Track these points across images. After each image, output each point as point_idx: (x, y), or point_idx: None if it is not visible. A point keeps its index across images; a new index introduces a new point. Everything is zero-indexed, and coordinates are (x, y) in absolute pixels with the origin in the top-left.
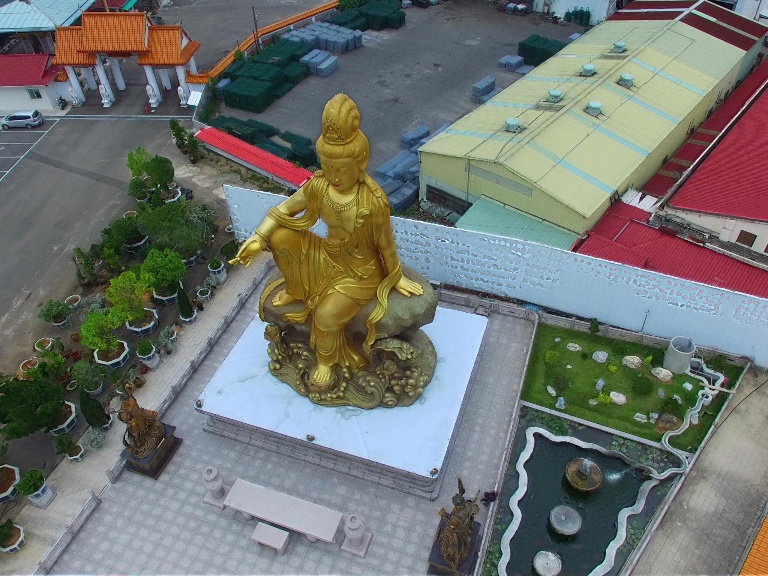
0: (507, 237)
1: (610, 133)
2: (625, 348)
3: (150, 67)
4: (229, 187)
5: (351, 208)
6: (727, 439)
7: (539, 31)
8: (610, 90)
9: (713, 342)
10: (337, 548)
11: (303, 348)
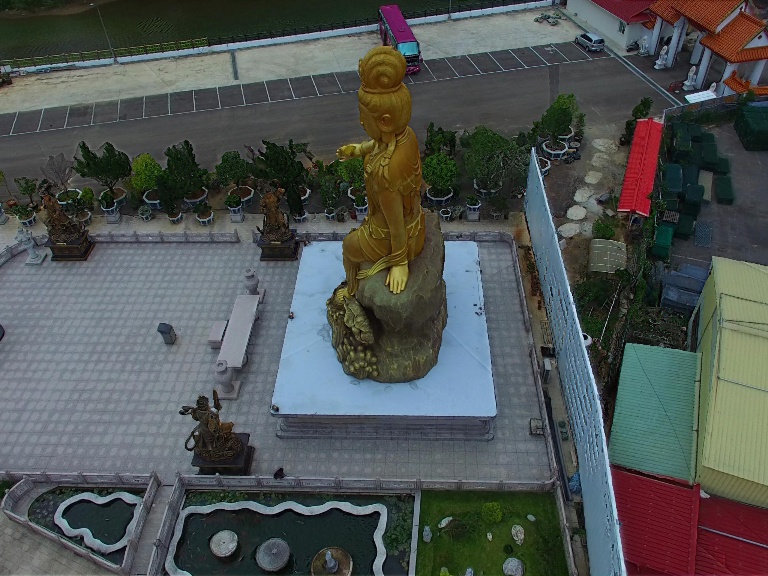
0: None
1: None
2: None
3: (710, 50)
4: (533, 152)
5: None
6: None
7: None
8: None
9: None
10: None
11: None
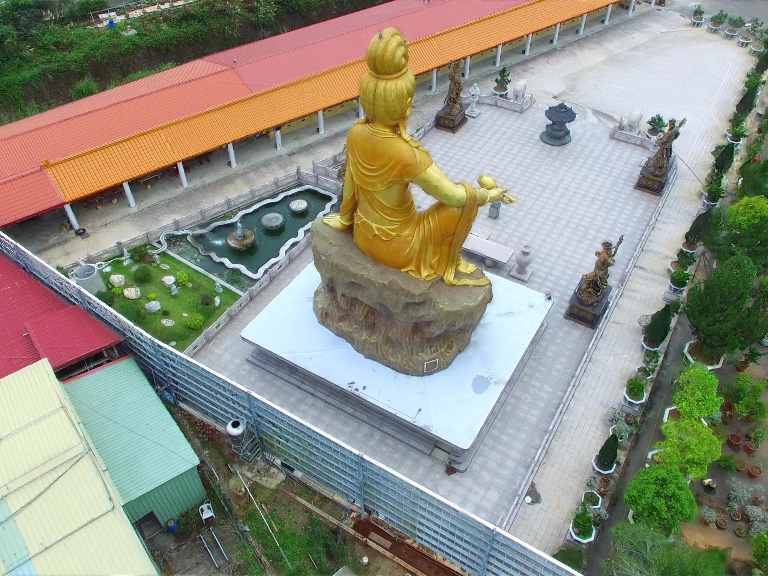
0: (171, 349)
1: None
2: None
3: None
4: None
5: None
6: None
7: None
8: None
9: None
10: None
11: None
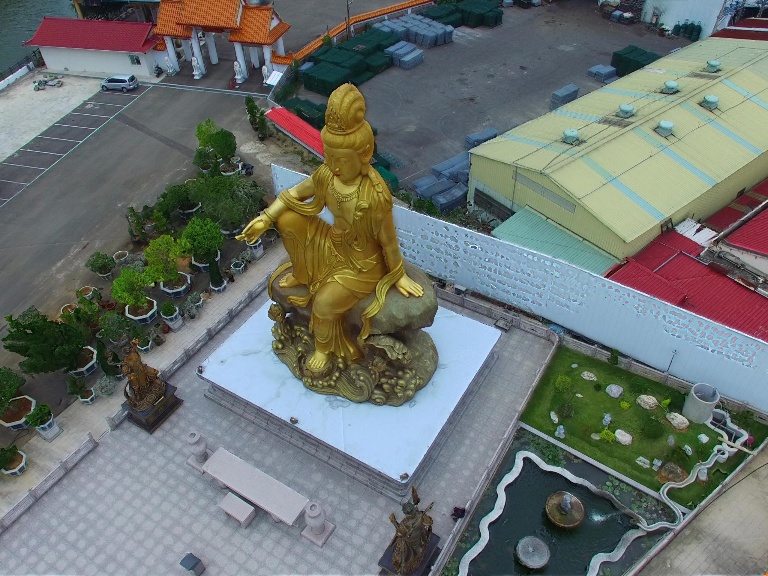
0: (535, 251)
1: (677, 156)
2: (643, 386)
3: (240, 44)
4: (276, 167)
5: (352, 199)
6: (735, 503)
7: (642, 42)
8: (689, 111)
9: (744, 396)
10: (298, 532)
11: (305, 332)
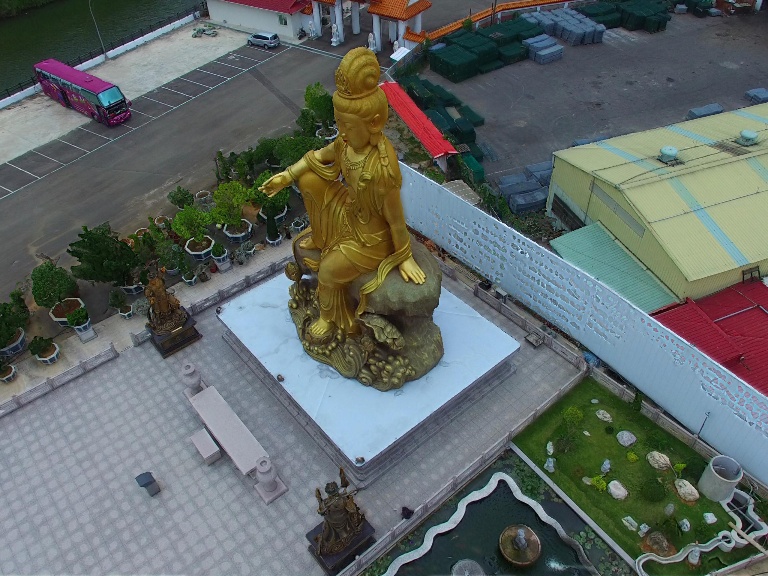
0: None
1: None
2: (661, 442)
3: (378, 16)
4: None
5: (358, 168)
6: None
7: None
8: None
9: None
10: (252, 484)
11: None
